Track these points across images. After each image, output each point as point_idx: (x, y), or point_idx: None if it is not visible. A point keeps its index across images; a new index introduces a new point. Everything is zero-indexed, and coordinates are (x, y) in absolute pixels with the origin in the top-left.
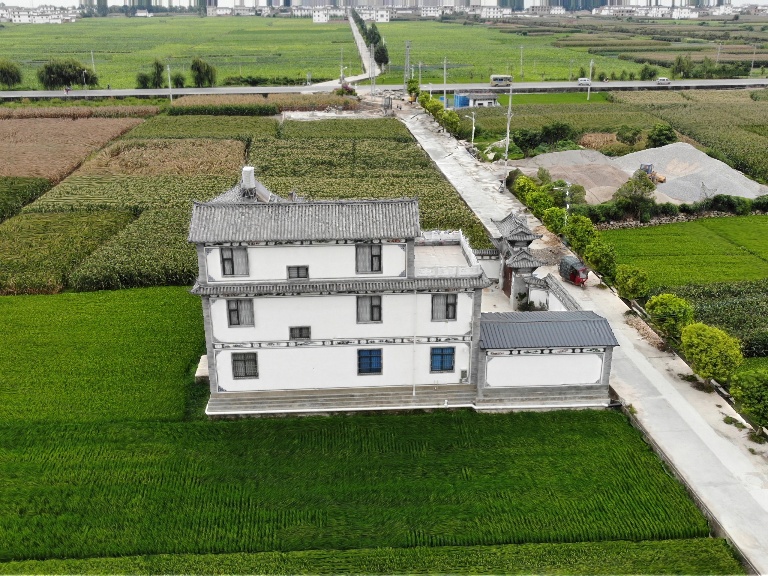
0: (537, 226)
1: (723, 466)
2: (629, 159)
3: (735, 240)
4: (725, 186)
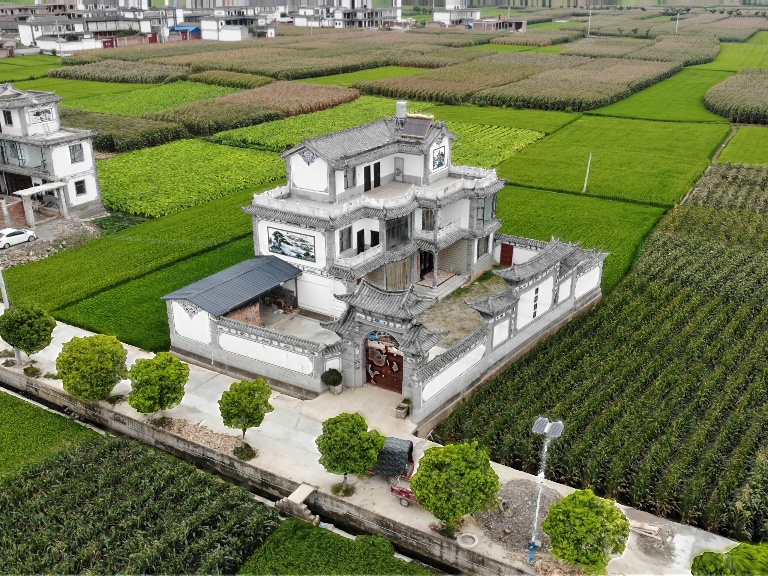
0: None
1: (53, 343)
2: None
3: None
4: None
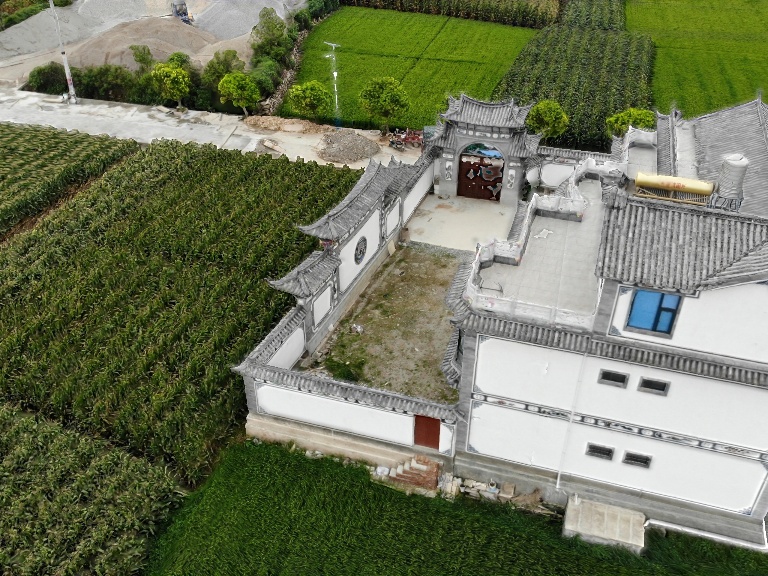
0: (239, 120)
1: None
2: (95, 6)
3: (381, 52)
4: (274, 3)
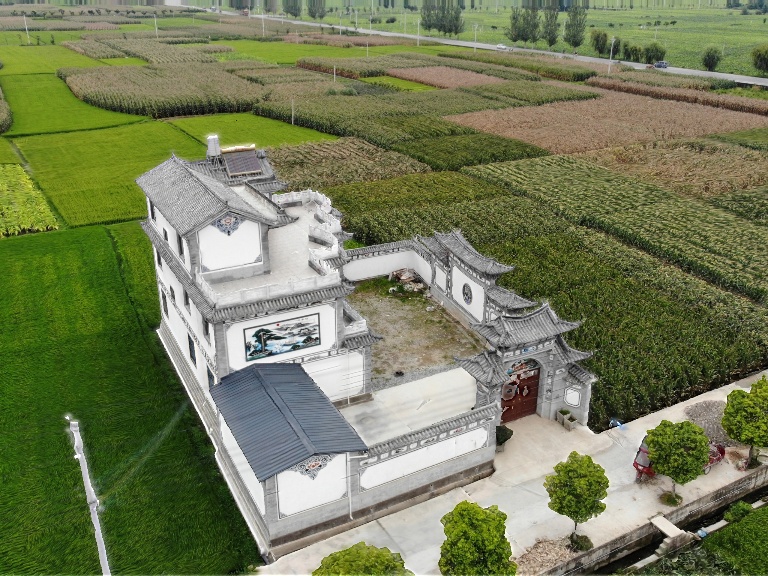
0: None
1: None
2: None
3: None
4: None
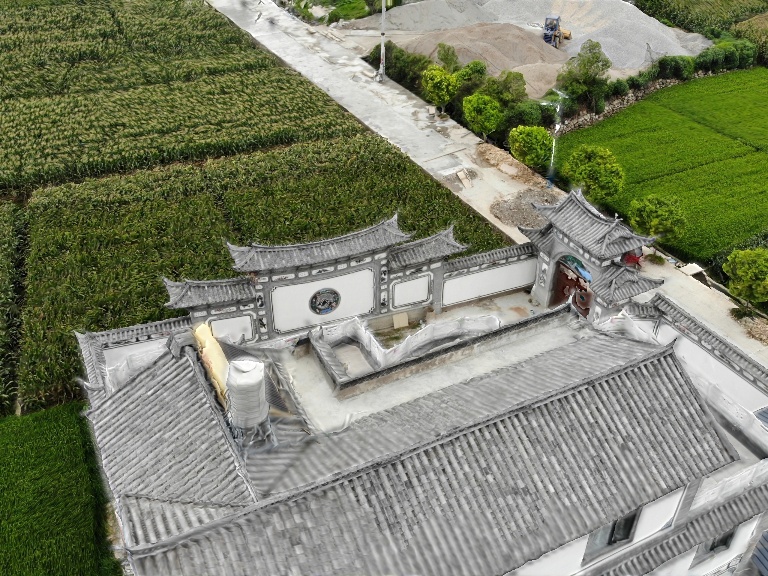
0: (476, 144)
1: None
2: (502, 3)
3: (722, 128)
4: (658, 41)
